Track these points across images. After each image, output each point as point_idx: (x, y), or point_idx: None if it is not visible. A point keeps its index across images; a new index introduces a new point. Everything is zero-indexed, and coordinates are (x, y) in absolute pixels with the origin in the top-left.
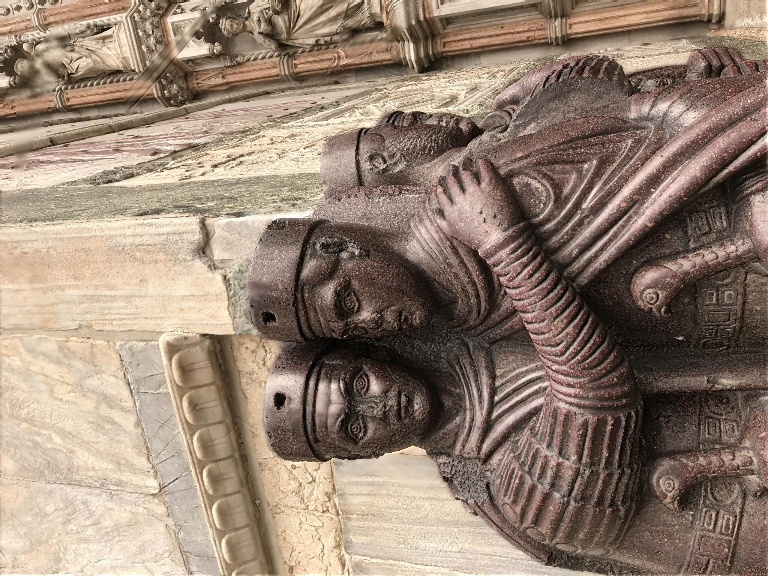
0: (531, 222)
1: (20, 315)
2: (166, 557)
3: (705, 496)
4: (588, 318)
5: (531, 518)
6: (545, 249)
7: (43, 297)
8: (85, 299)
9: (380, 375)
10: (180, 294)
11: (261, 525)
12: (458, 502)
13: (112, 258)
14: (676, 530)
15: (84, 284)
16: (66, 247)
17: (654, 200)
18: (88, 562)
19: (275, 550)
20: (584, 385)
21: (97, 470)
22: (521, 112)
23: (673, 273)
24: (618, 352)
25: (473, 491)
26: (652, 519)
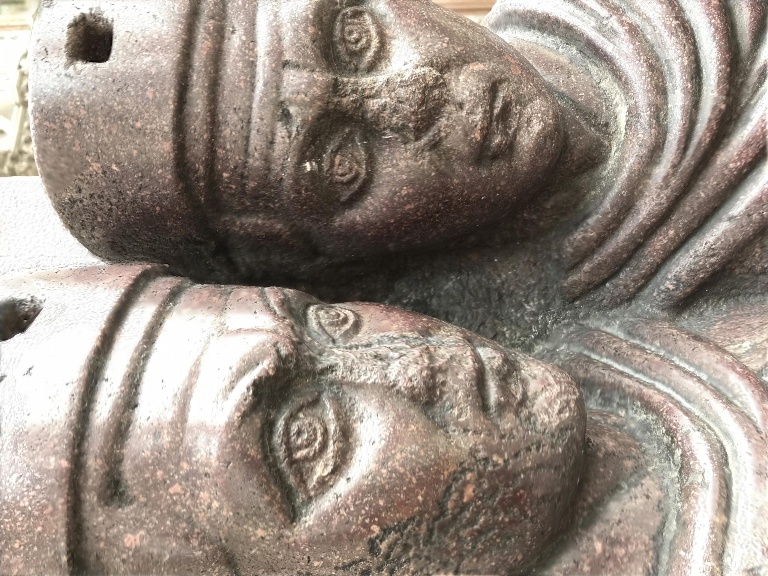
0: None
1: None
2: None
3: None
4: None
5: None
6: None
7: None
8: None
9: (395, 307)
10: None
11: None
12: None
13: None
14: None
15: None
16: None
17: None
18: None
19: None
20: None
21: None
22: None
23: None
24: None
25: None
26: None
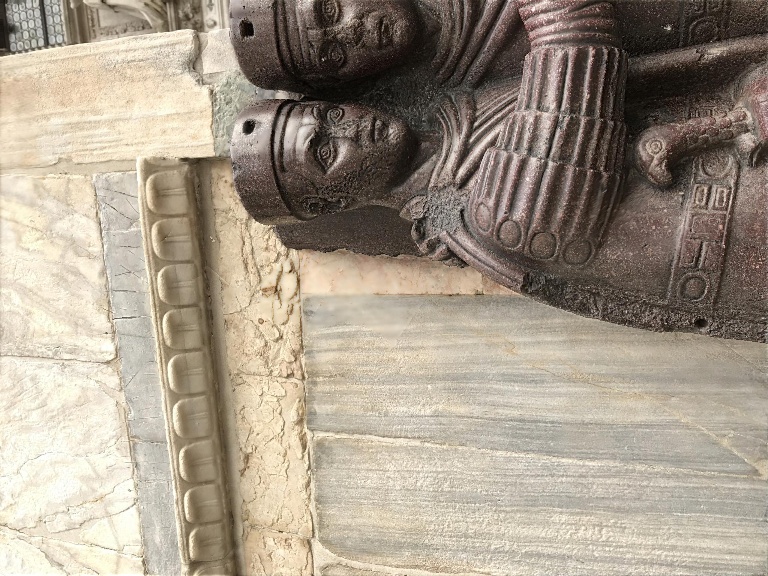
0: None
1: (2, 153)
2: (111, 445)
3: (696, 173)
4: None
5: (505, 204)
6: None
7: (28, 129)
8: (69, 128)
9: (356, 107)
10: (165, 113)
11: (219, 400)
12: (434, 350)
13: (102, 78)
14: (665, 214)
15: (71, 111)
16: (59, 70)
17: None
18: (26, 459)
19: (231, 433)
20: (564, 15)
21: (53, 335)
22: None
23: None
24: None
25: (446, 224)
26: (638, 205)
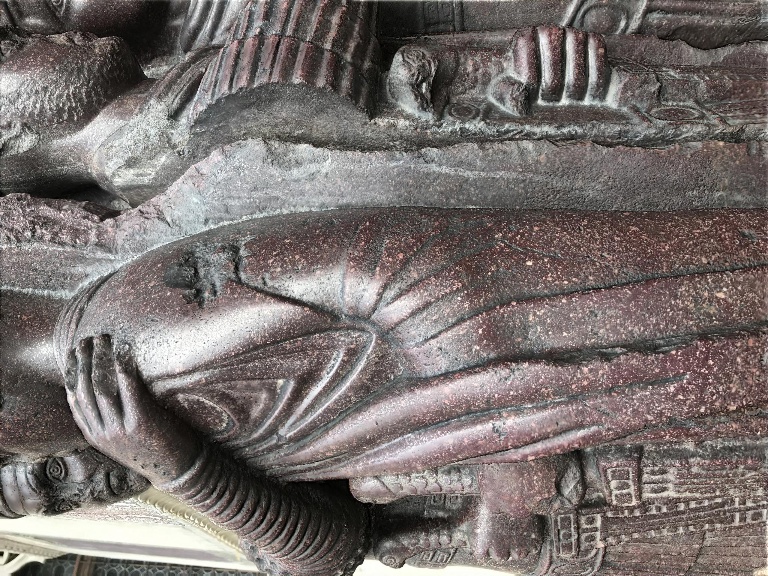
0: (213, 441)
1: None
2: None
3: None
4: (296, 526)
5: None
6: (237, 458)
7: None
8: None
9: (77, 458)
10: None
11: None
12: None
13: None
14: None
15: None
16: None
17: (367, 462)
18: None
19: None
20: (297, 567)
21: None
22: (200, 118)
23: (392, 495)
24: (333, 534)
25: None
26: None
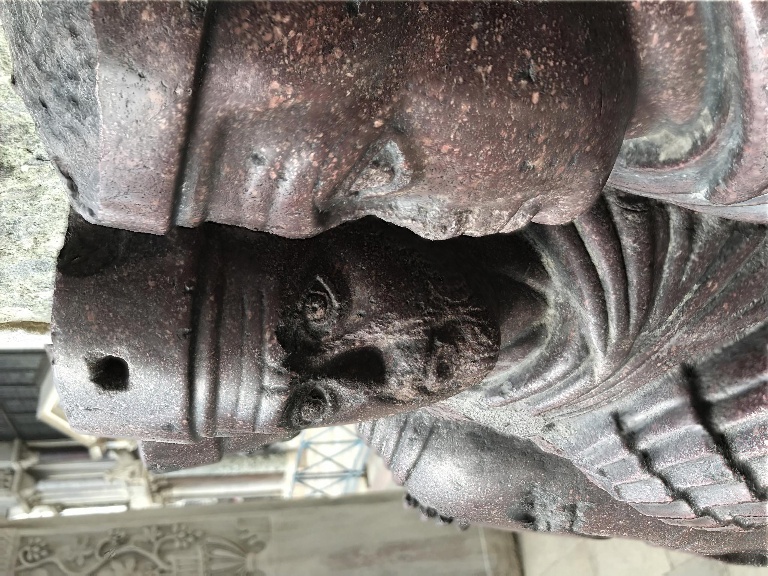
0: None
1: None
2: None
3: None
4: None
5: None
6: None
7: None
8: None
9: None
10: None
11: None
12: None
13: None
14: None
15: None
16: None
17: None
18: None
19: None
20: None
21: None
22: None
23: None
24: None
25: None
26: None
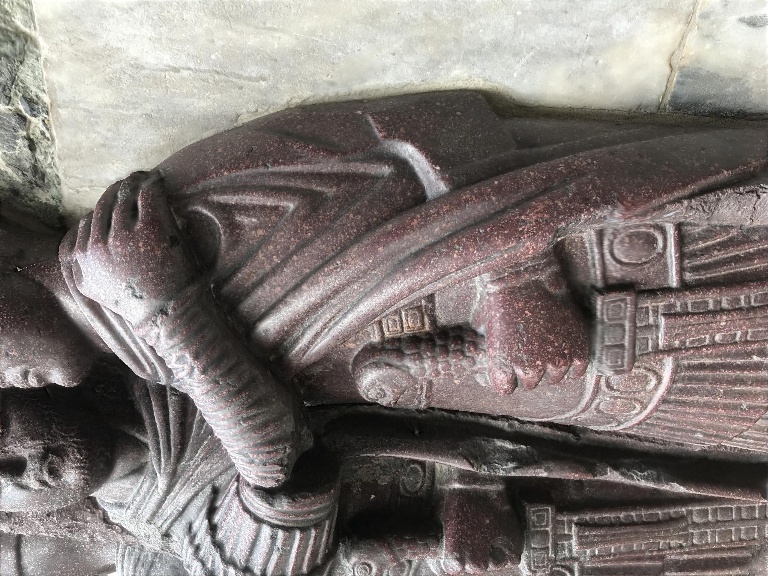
0: None
1: None
2: None
3: None
4: None
5: None
6: None
7: None
8: None
9: None
10: None
11: None
12: None
13: None
14: None
15: None
16: None
17: None
18: None
19: None
20: None
21: None
22: None
23: None
24: None
25: None
26: None
